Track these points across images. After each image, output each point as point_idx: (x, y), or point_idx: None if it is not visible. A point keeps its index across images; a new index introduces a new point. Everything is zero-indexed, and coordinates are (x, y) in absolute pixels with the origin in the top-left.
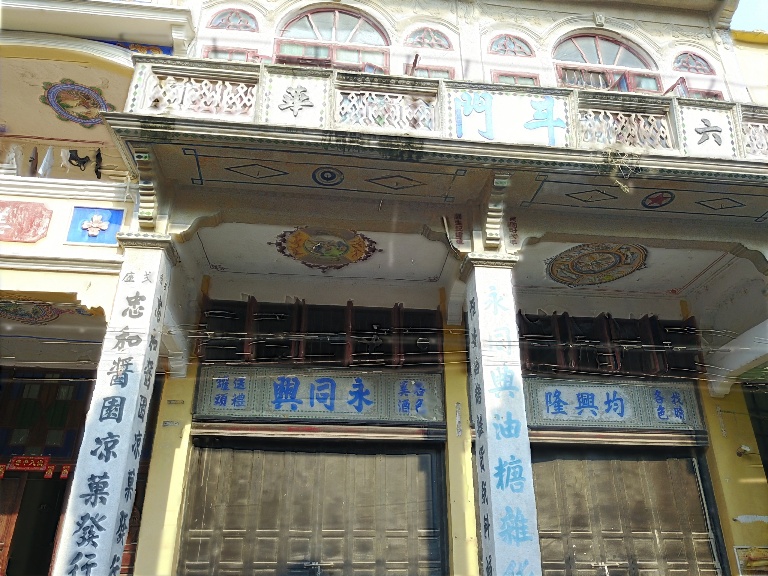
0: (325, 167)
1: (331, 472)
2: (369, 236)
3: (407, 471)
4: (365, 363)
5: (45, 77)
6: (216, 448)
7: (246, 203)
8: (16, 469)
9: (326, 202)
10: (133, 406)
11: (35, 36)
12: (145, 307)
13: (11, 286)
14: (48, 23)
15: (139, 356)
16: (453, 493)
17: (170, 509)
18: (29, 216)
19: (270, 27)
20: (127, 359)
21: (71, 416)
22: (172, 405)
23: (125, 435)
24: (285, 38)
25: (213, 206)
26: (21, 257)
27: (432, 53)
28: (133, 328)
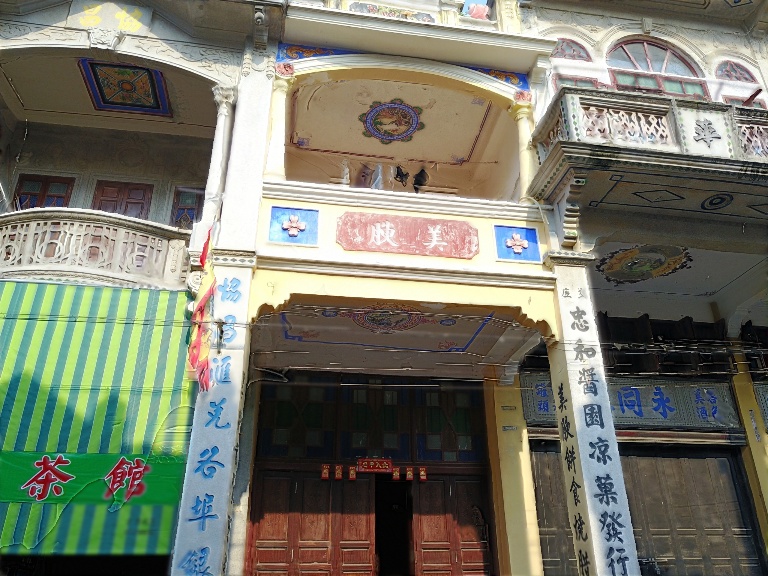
0: (723, 194)
1: (645, 474)
2: (692, 255)
3: (711, 474)
4: (660, 372)
5: (379, 97)
6: (541, 451)
7: (634, 224)
8: (366, 471)
9: (699, 225)
10: (610, 413)
11: (411, 61)
12: (589, 321)
13: (464, 300)
14: (428, 49)
15: (599, 367)
16: (766, 494)
17: (528, 509)
18: (459, 234)
19: (601, 57)
20: (590, 370)
21: (401, 420)
22: (507, 411)
23: (612, 440)
24: (616, 68)
25: (608, 227)
26: (471, 273)
27: (742, 85)
28: (585, 341)
